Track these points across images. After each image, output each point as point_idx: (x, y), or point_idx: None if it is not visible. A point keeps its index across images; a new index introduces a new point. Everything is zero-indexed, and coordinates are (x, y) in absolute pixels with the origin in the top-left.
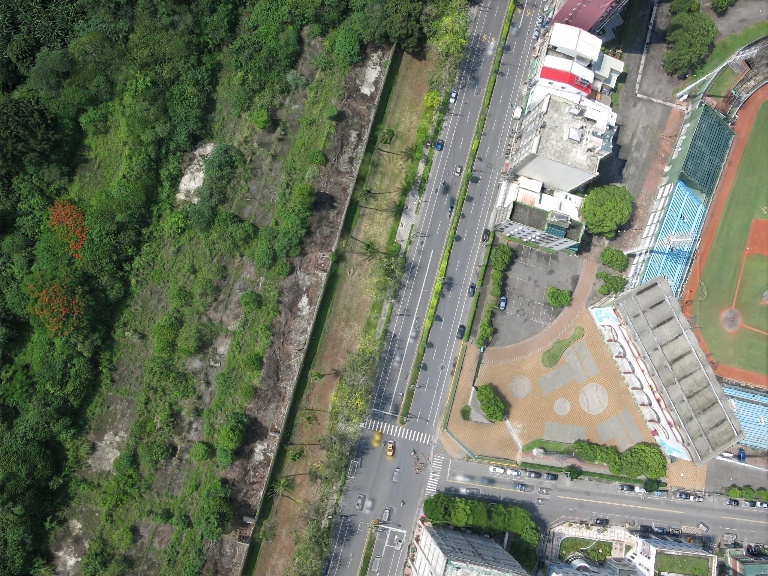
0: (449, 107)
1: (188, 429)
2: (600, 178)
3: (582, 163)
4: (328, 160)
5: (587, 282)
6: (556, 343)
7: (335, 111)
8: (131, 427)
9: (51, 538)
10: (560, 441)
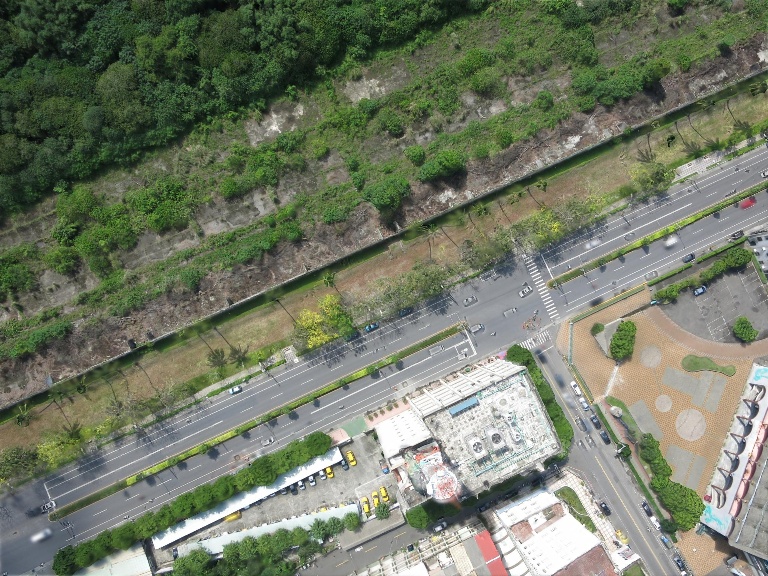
0: None
1: (422, 132)
2: None
3: None
4: (688, 71)
5: None
6: (707, 358)
7: (732, 43)
8: (393, 91)
9: (280, 100)
10: (637, 423)
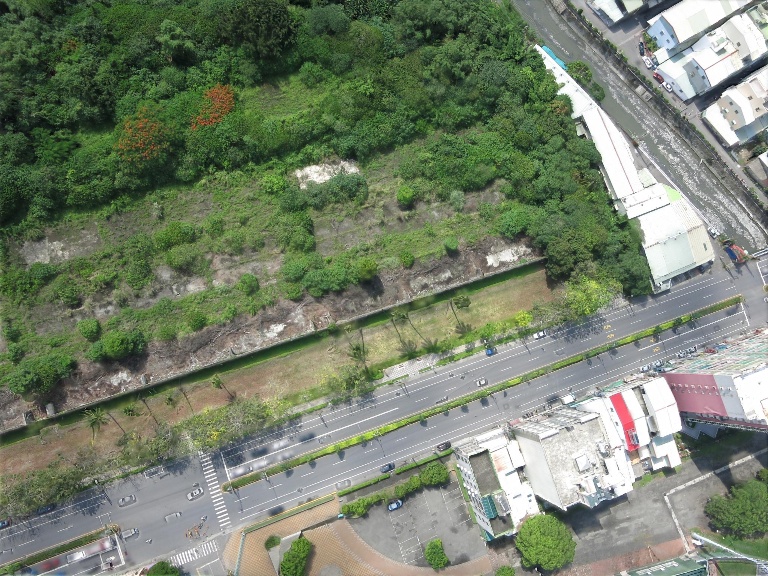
0: (529, 337)
1: (104, 305)
2: (569, 515)
3: (564, 488)
4: (411, 268)
5: (469, 572)
6: None
7: (454, 246)
8: (76, 257)
9: None
10: None
